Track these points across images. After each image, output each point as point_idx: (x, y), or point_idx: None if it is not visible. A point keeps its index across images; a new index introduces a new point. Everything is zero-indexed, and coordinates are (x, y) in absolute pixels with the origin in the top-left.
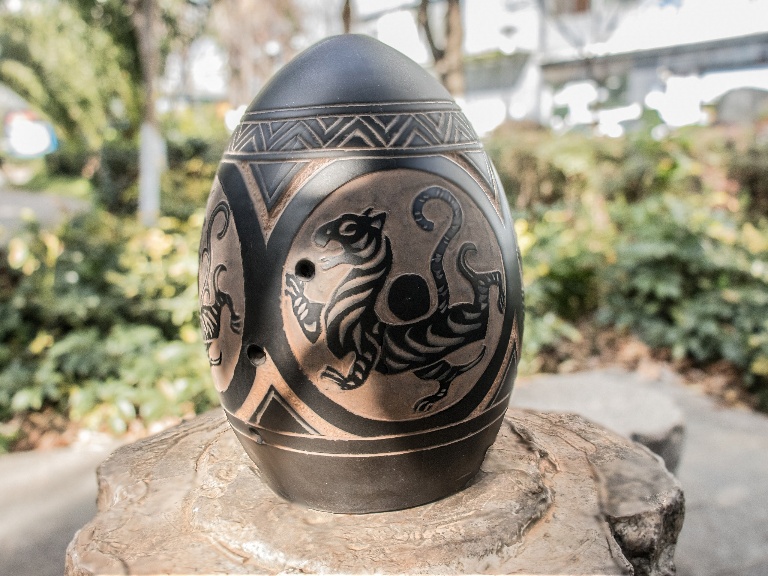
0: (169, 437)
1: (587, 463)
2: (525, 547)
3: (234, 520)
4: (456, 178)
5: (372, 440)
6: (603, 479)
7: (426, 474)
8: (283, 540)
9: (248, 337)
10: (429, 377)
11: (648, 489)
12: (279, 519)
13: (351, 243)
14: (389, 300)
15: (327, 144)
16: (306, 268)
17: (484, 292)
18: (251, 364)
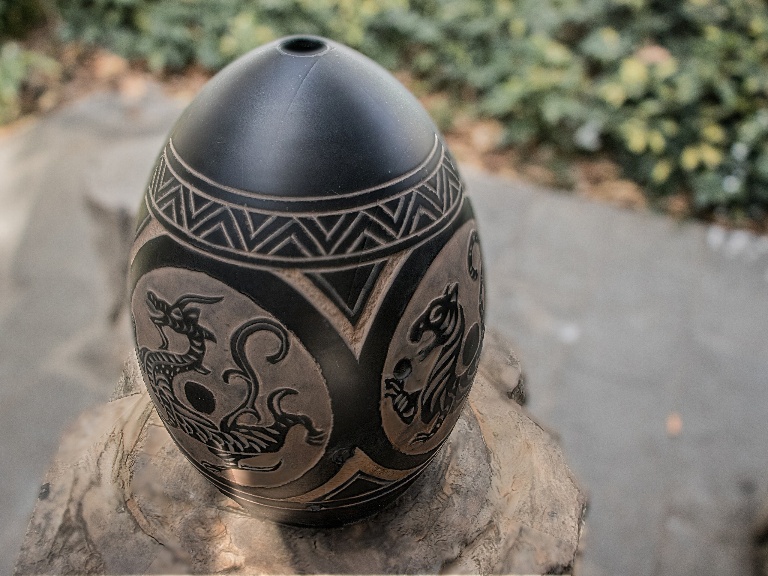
0: (62, 520)
1: None
2: (496, 455)
3: None
4: None
5: None
6: None
7: None
8: (366, 571)
9: (335, 445)
10: None
11: (502, 352)
12: (335, 552)
13: (439, 326)
14: None
15: (400, 234)
16: (401, 365)
17: None
18: (336, 464)
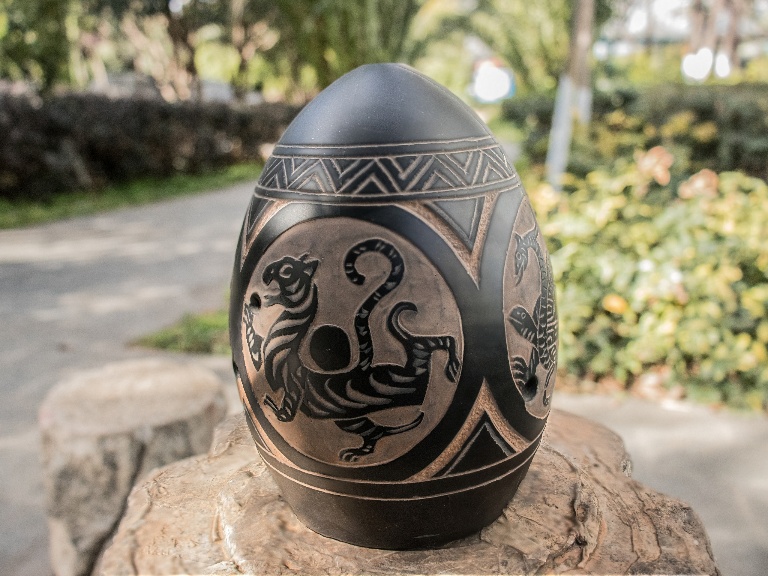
0: None
1: (624, 571)
2: None
3: (239, 502)
4: (407, 230)
5: (307, 473)
6: None
7: (370, 521)
8: (247, 534)
9: (232, 351)
10: (351, 430)
11: None
12: (266, 514)
13: (286, 286)
14: (311, 347)
15: (290, 185)
16: (258, 301)
17: (423, 356)
18: None
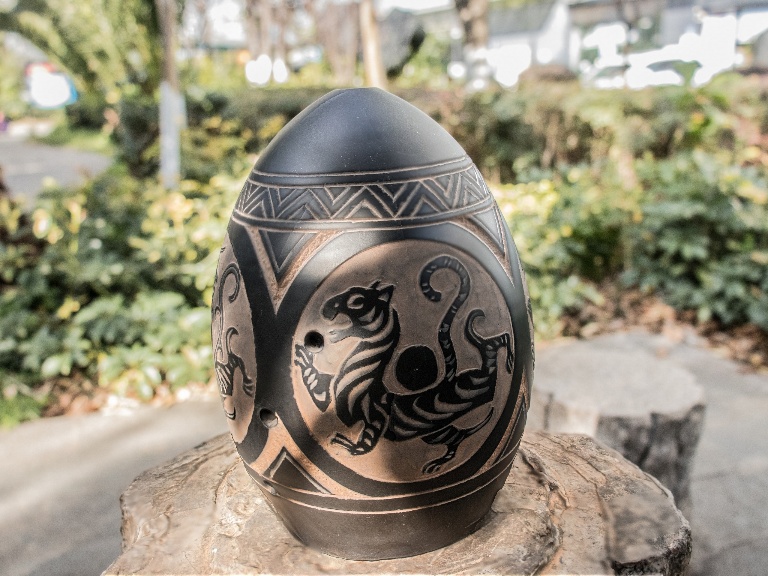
0: (190, 462)
1: (596, 498)
2: None
3: (251, 564)
4: (464, 244)
5: (382, 500)
6: (611, 517)
7: (435, 526)
8: None
9: (260, 401)
10: (437, 442)
11: (655, 530)
12: (294, 565)
13: (359, 316)
14: (397, 371)
15: (335, 215)
16: (315, 339)
17: (492, 356)
18: (264, 426)
